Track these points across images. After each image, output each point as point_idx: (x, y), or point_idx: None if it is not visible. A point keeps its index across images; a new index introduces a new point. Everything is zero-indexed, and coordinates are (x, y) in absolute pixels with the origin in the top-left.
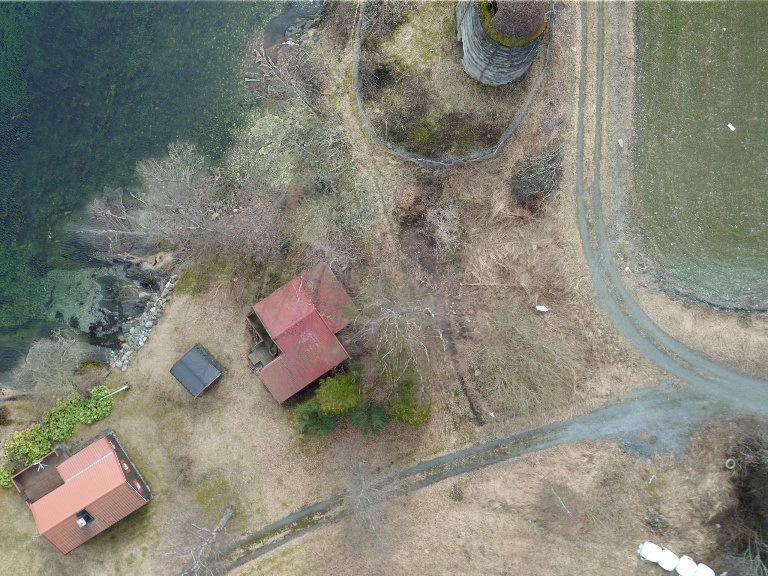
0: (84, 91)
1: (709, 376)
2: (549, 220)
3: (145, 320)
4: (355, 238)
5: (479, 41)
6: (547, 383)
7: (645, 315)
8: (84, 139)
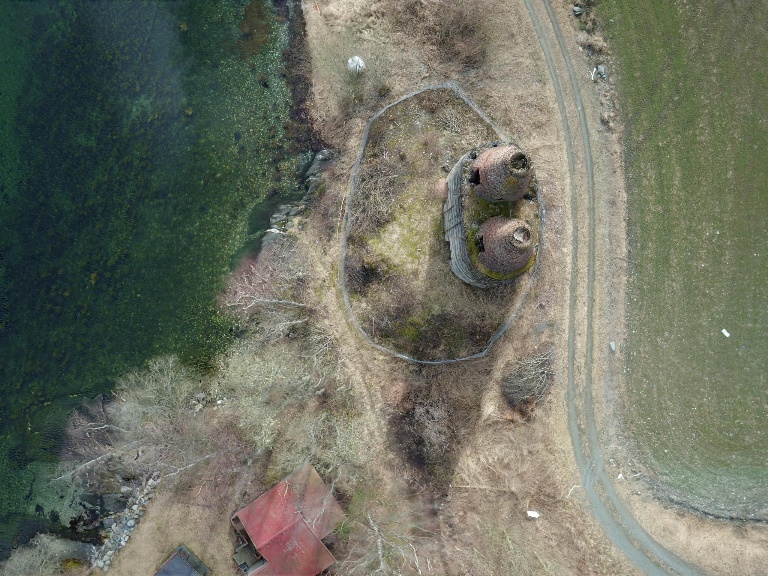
0: (64, 277)
1: None
2: (540, 424)
3: (127, 518)
4: (342, 438)
5: (466, 266)
6: None
7: (638, 525)
8: (64, 326)
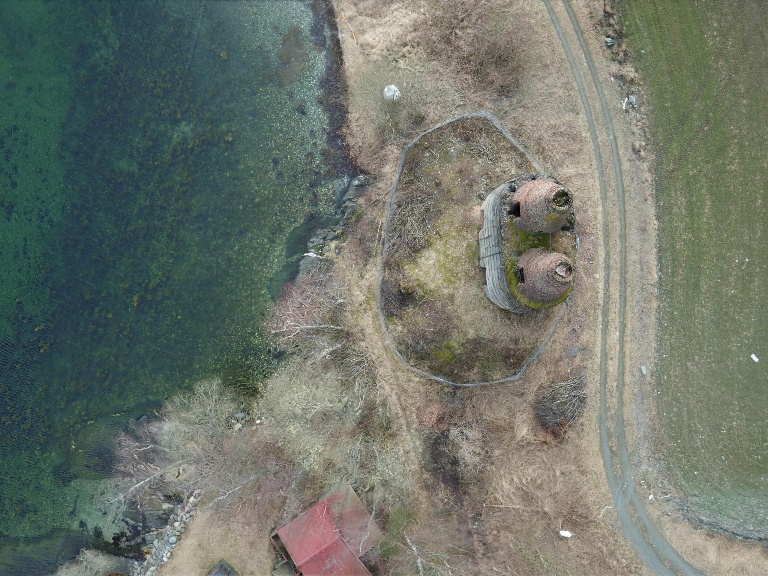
0: (106, 299)
1: None
2: (572, 446)
3: (169, 534)
4: None
5: (505, 295)
6: None
7: (669, 545)
8: (107, 347)
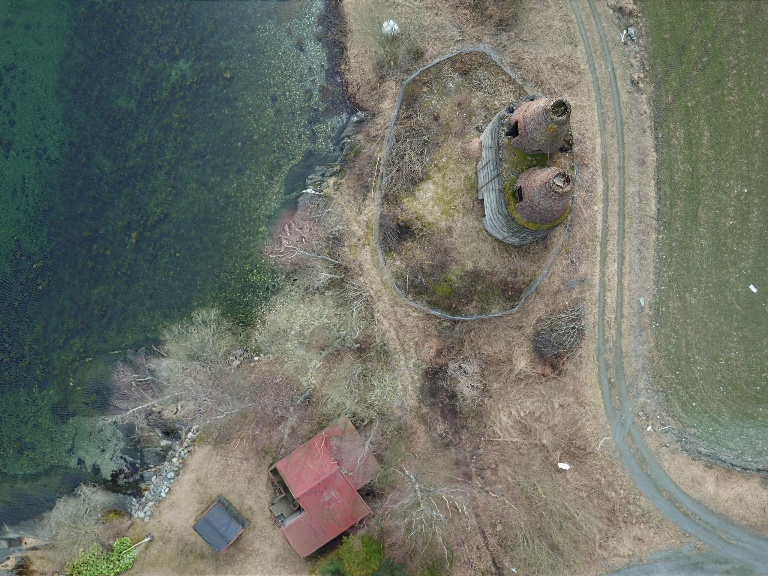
0: (105, 237)
1: (732, 540)
2: (571, 378)
3: (167, 470)
4: None
5: (503, 219)
6: (569, 540)
7: (667, 476)
8: (105, 285)
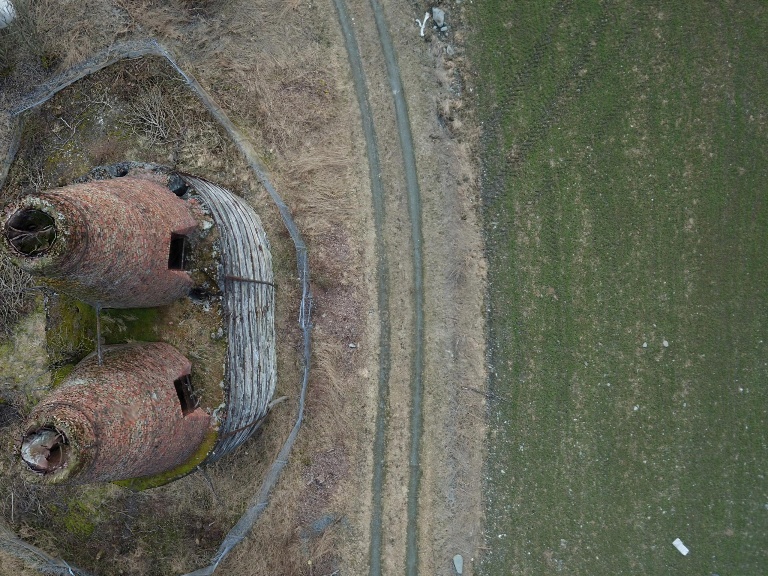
0: None
1: None
2: None
3: None
4: None
5: None
6: None
7: None
8: None
